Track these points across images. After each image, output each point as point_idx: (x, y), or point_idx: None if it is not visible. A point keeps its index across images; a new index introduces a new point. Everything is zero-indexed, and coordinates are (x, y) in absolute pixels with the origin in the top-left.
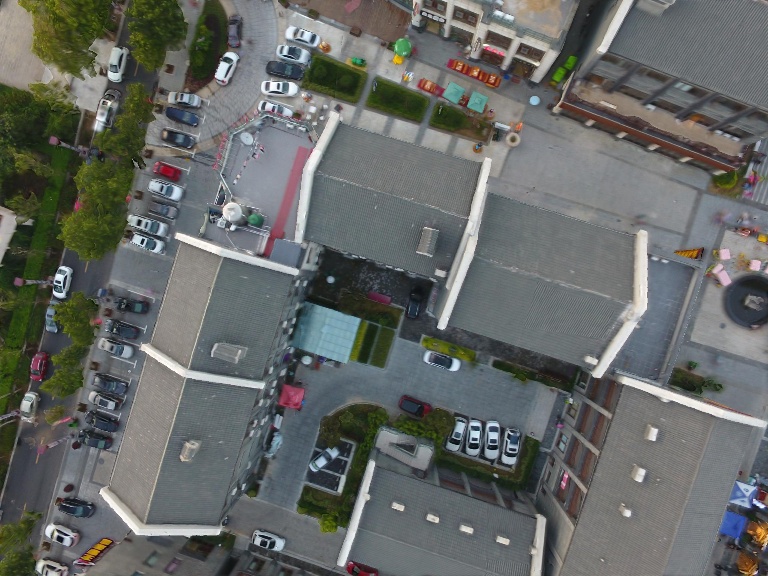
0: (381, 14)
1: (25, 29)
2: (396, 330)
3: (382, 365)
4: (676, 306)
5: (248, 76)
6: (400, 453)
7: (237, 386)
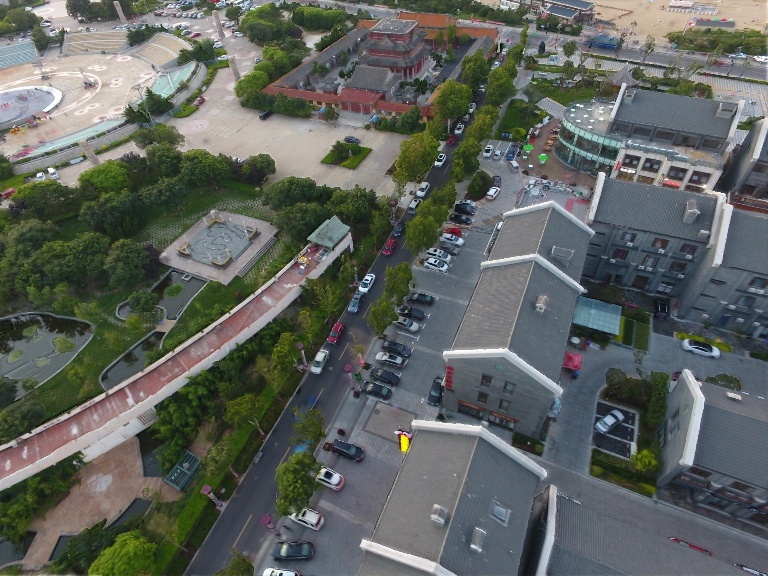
0: (586, 179)
1: (366, 177)
2: (650, 326)
3: (646, 348)
4: None
5: (505, 198)
6: None
7: (564, 284)
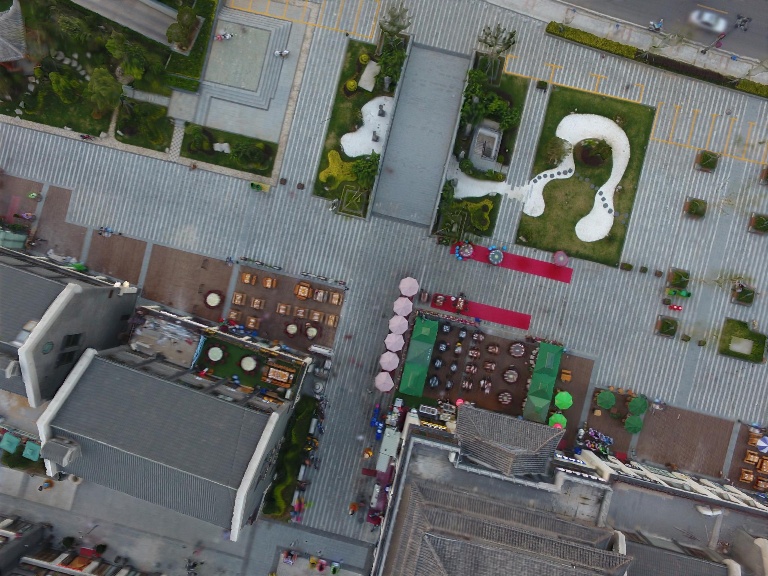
0: None
1: None
2: None
3: None
4: None
5: None
6: None
7: None
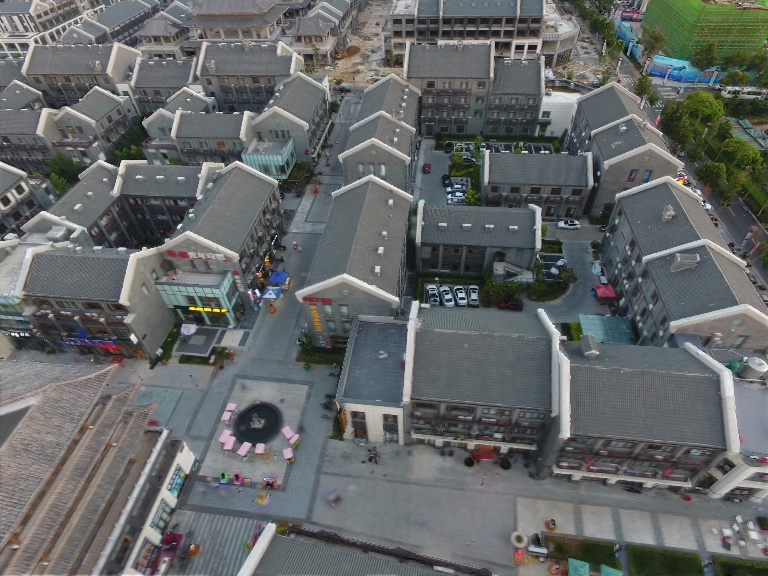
0: None
1: None
2: None
3: None
4: (352, 372)
5: None
6: (514, 269)
7: None
